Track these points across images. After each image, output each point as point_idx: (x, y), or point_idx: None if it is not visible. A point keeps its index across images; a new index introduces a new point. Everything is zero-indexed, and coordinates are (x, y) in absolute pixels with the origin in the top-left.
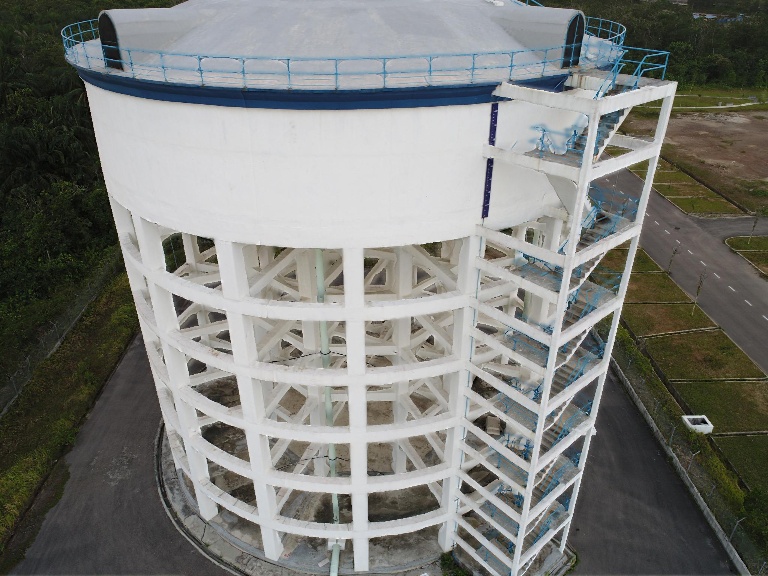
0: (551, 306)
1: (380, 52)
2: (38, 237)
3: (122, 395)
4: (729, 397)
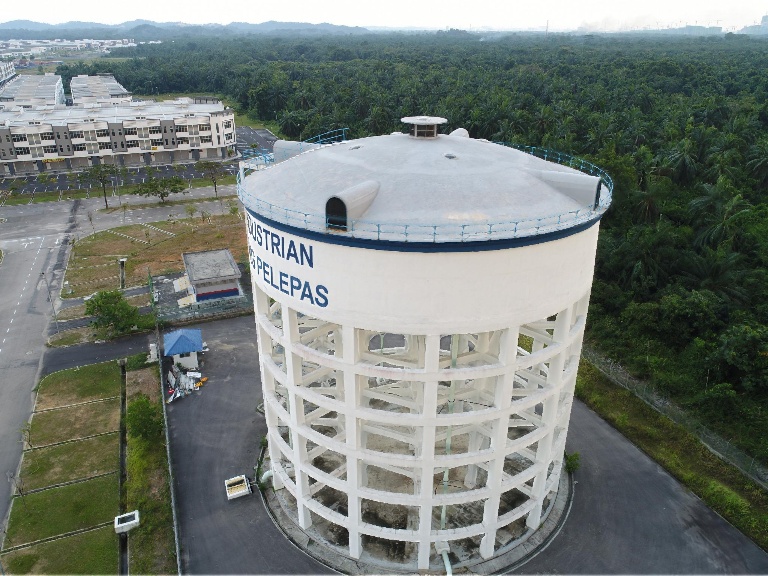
0: (277, 304)
1: None
2: None
3: (595, 428)
4: (66, 571)
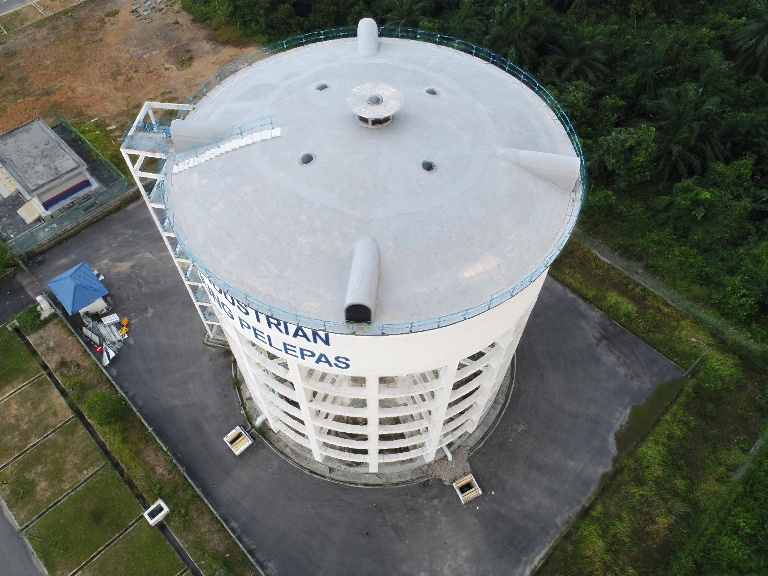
0: None
1: (254, 79)
2: (767, 271)
3: None
4: None
